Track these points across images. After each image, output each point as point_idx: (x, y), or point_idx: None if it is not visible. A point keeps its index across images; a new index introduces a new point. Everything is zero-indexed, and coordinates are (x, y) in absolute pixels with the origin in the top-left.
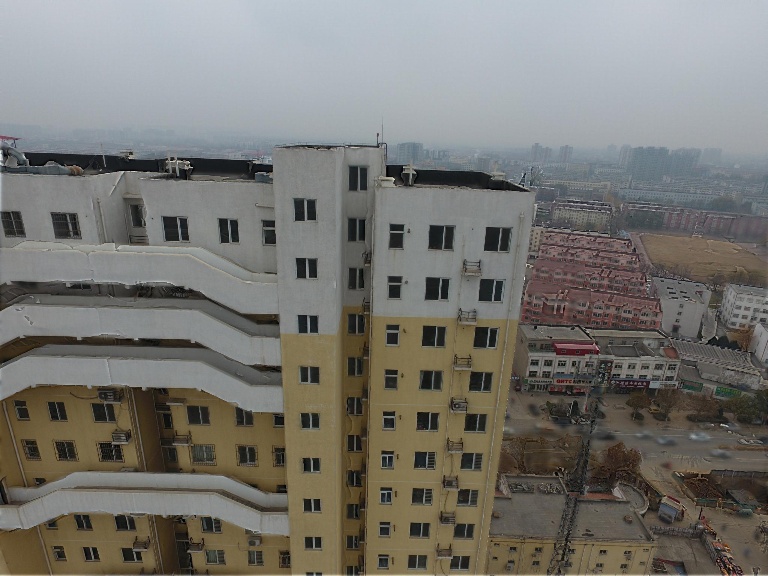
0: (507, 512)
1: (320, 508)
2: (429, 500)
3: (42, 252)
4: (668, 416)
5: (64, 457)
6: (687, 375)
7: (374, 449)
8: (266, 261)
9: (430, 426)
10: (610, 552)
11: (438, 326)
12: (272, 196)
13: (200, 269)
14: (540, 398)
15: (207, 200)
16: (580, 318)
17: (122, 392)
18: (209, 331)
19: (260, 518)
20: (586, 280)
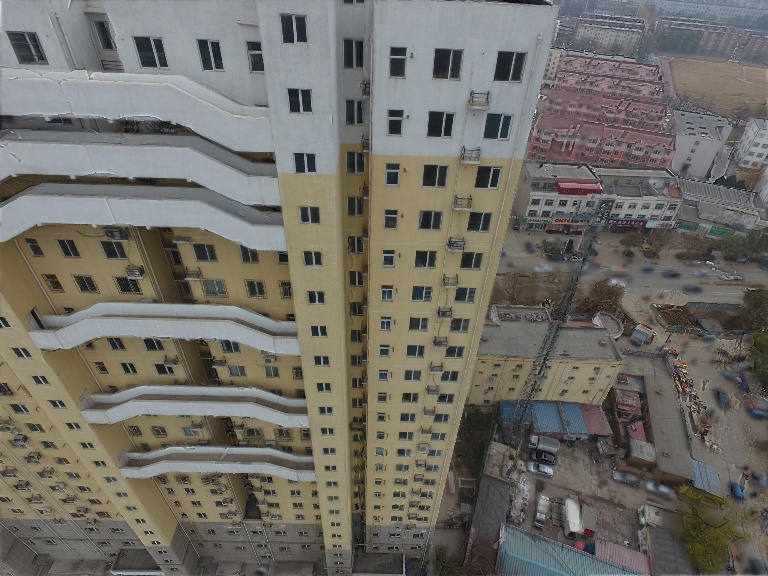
0: (495, 336)
1: (326, 333)
2: (425, 327)
3: (9, 81)
4: (658, 254)
5: (85, 290)
6: (686, 215)
7: (374, 284)
8: (255, 92)
9: (428, 263)
10: (582, 368)
11: (440, 165)
12: (255, 10)
13: (185, 101)
14: (537, 237)
15: (181, 16)
16: (588, 156)
17: (127, 231)
18: (204, 170)
19: (273, 341)
20: (601, 113)
